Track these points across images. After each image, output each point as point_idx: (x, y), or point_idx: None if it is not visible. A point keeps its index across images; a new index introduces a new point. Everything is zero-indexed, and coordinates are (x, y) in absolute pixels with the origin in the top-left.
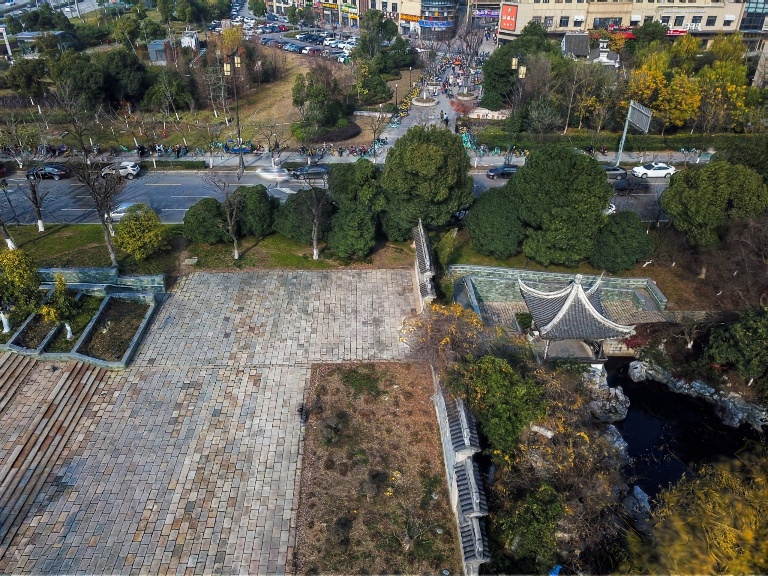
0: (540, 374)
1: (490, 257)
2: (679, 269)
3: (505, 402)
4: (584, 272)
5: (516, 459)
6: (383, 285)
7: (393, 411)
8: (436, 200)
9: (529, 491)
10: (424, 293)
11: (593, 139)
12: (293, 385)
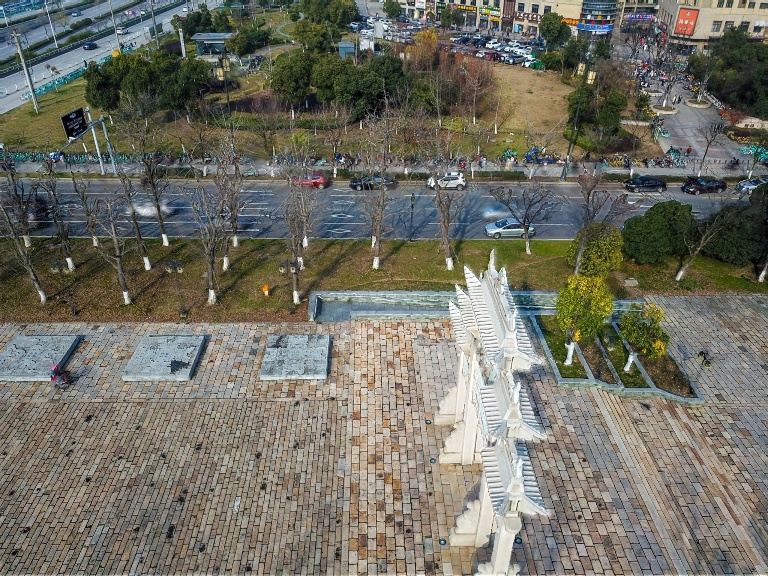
0: None
1: None
2: None
3: None
4: None
5: None
6: None
7: None
8: None
9: None
10: None
11: None
12: None
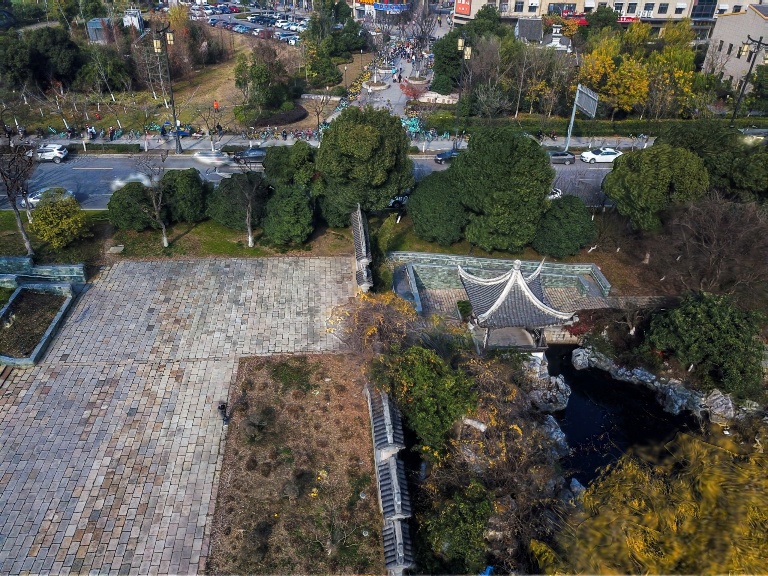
0: (474, 364)
1: (434, 243)
2: (623, 254)
3: (433, 395)
4: (529, 258)
5: (446, 455)
6: (321, 273)
7: (323, 406)
8: (374, 184)
9: (458, 488)
10: (360, 281)
11: (543, 124)
12: (218, 380)
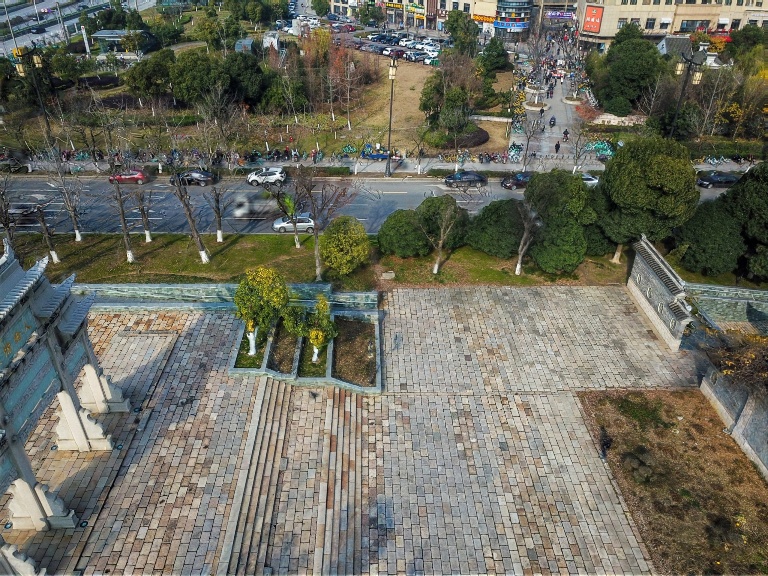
0: None
1: (696, 273)
2: None
3: None
4: None
5: None
6: (603, 304)
7: (693, 446)
8: (671, 215)
9: None
10: (682, 316)
11: (738, 147)
12: (569, 415)
